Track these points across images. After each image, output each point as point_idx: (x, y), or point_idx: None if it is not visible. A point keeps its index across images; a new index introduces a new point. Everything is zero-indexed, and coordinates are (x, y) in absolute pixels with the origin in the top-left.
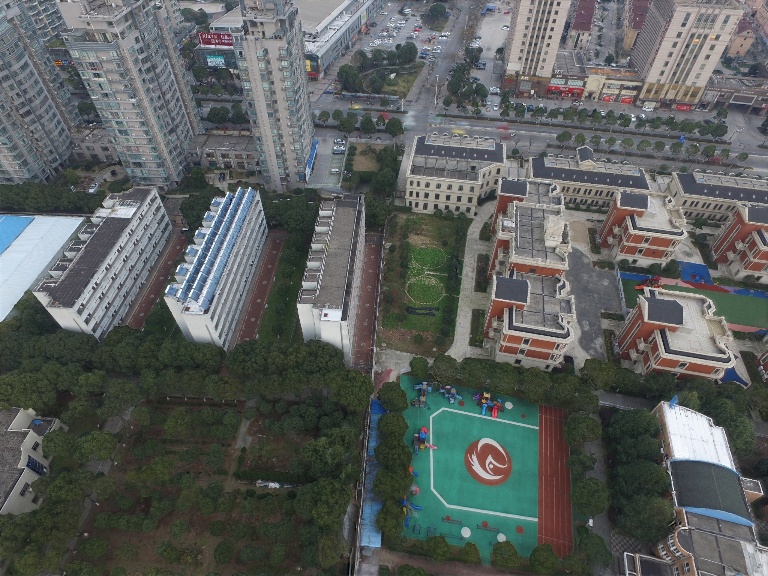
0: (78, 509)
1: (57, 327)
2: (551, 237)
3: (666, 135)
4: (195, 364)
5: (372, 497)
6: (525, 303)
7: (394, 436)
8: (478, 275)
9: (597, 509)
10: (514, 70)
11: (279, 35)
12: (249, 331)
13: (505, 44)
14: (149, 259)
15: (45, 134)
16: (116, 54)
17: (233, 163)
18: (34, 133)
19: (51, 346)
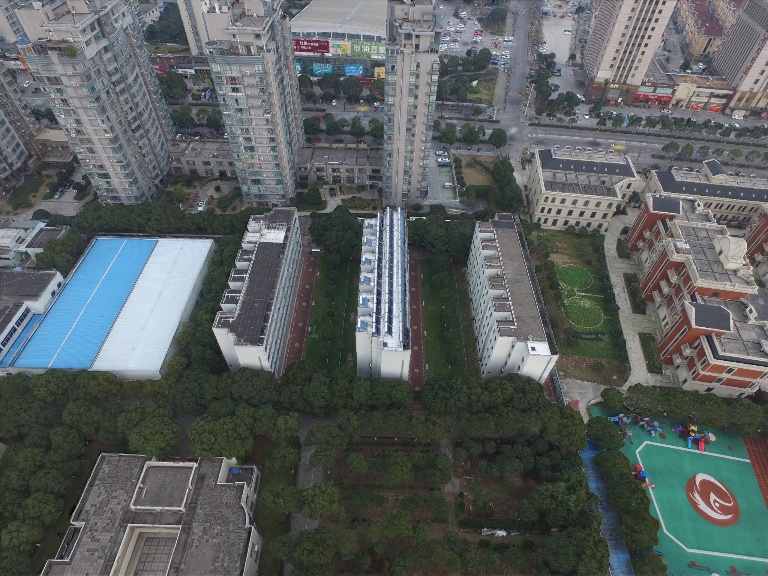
0: (332, 574)
1: (222, 362)
2: (733, 259)
3: (765, 145)
4: (390, 402)
5: (614, 544)
6: (728, 331)
7: (627, 478)
8: (632, 296)
9: None
10: (604, 78)
11: (435, 48)
12: (416, 361)
13: (573, 49)
14: (292, 284)
15: (151, 149)
16: (262, 68)
17: (343, 177)
18: (142, 148)
19: (239, 387)
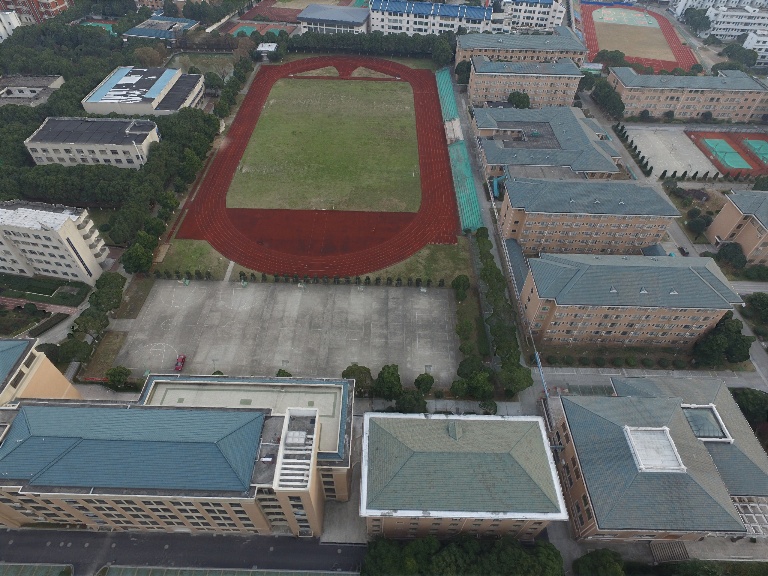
0: None
1: None
2: None
3: None
4: None
5: None
6: None
7: None
8: None
9: (122, 9)
10: None
11: None
12: None
13: None
14: None
15: None
16: None
17: None
18: None
19: None
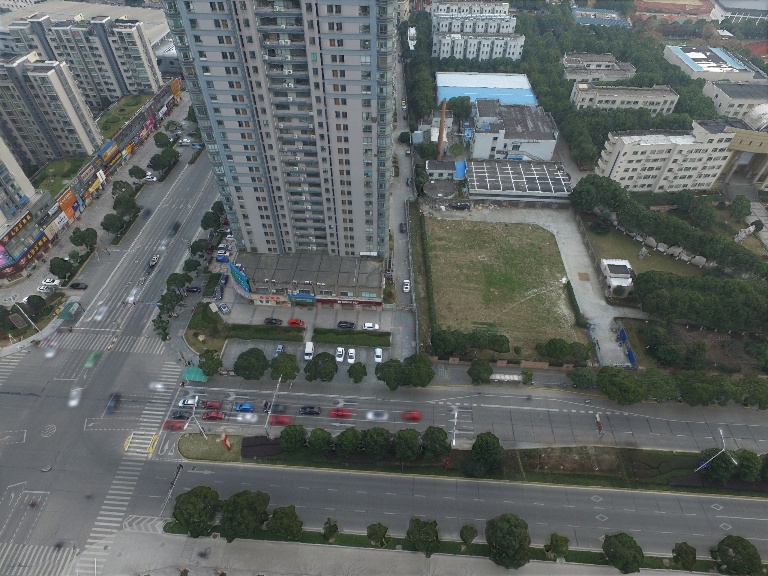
0: None
1: None
2: None
3: None
4: None
5: None
6: None
7: None
8: None
9: None
10: None
11: None
12: None
13: None
14: None
15: None
16: None
17: None
18: None
19: None
